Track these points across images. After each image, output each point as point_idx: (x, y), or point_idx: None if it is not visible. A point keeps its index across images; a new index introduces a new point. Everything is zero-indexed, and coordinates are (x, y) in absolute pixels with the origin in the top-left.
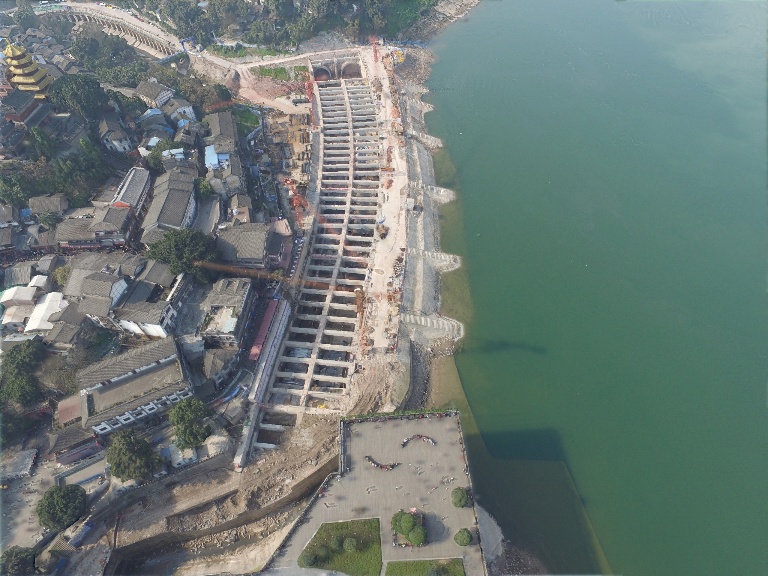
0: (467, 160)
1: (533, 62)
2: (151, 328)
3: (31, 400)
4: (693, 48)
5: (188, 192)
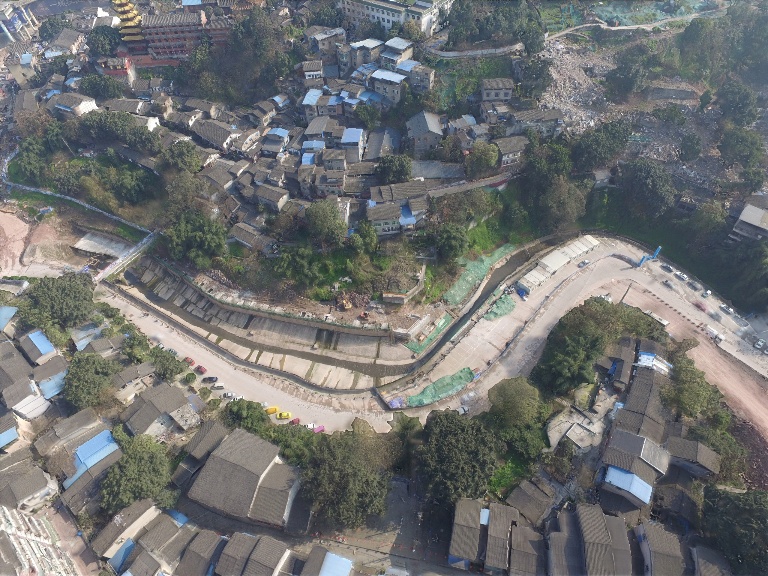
0: None
1: None
2: None
3: None
4: None
5: None
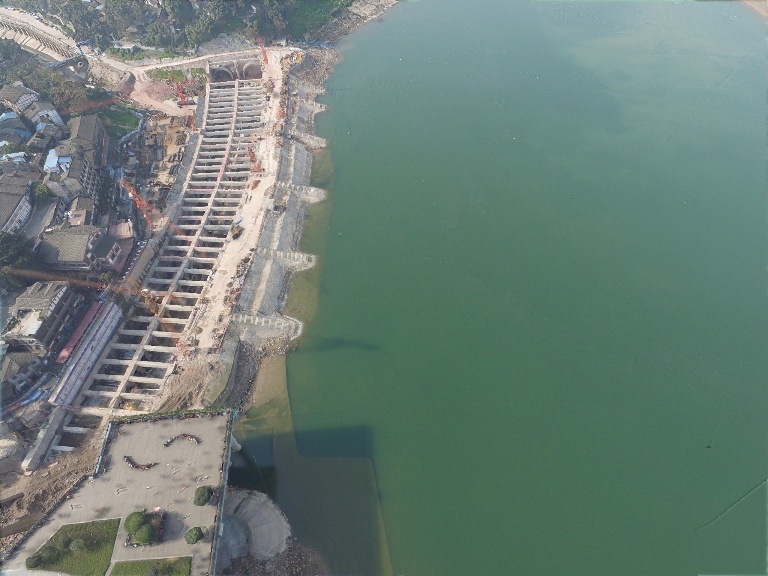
0: (347, 160)
1: (436, 61)
2: None
3: None
4: (597, 45)
5: (19, 195)
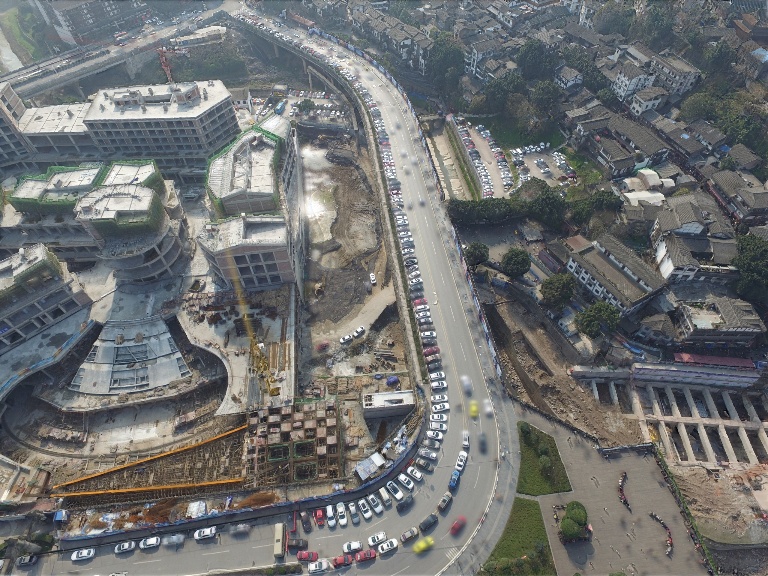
0: None
1: None
2: (667, 265)
3: (575, 220)
4: None
5: None
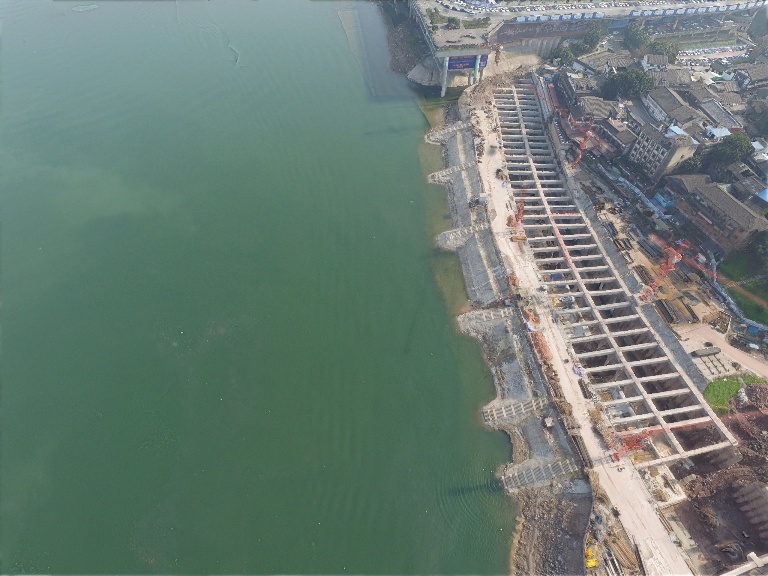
0: (423, 293)
1: None
2: None
3: None
4: None
5: None
